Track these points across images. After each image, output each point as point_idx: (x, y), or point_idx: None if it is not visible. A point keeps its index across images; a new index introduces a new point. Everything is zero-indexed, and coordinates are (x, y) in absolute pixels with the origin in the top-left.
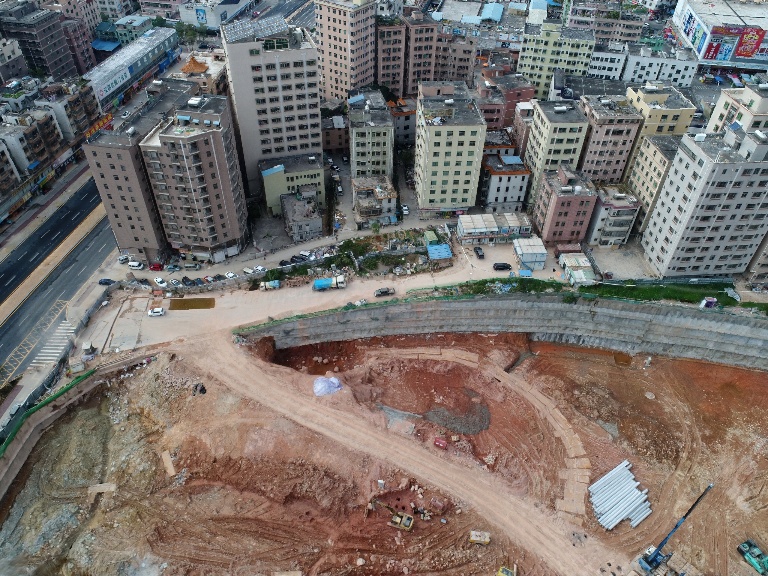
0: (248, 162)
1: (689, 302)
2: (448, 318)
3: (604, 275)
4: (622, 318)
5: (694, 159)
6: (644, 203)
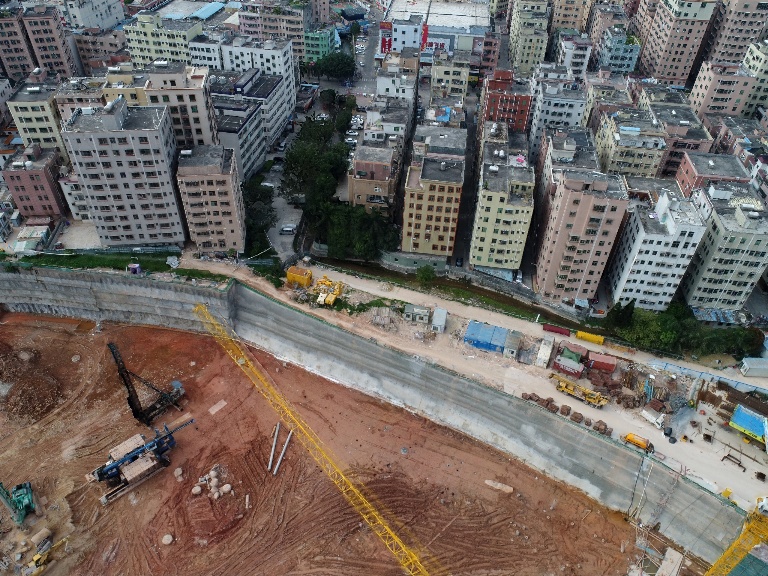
0: None
1: (120, 269)
2: None
3: None
4: (68, 286)
5: None
6: None
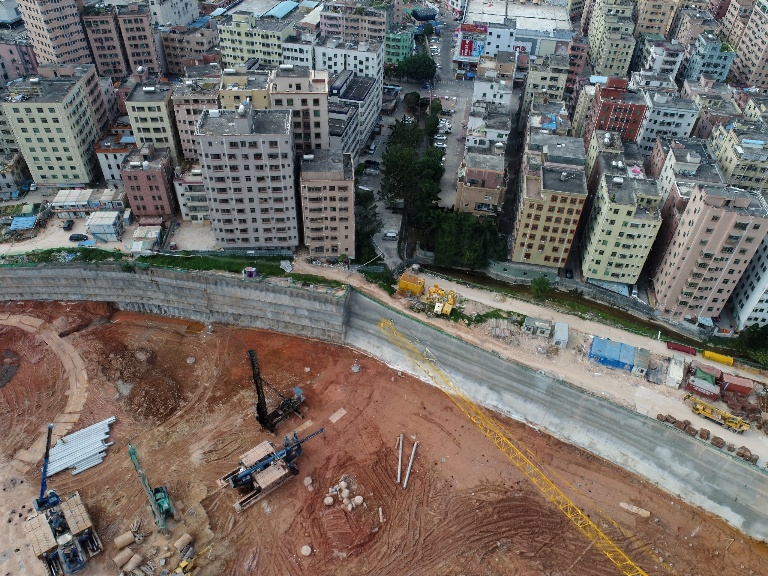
0: None
1: (236, 272)
2: (21, 286)
3: None
4: (181, 287)
5: None
6: None
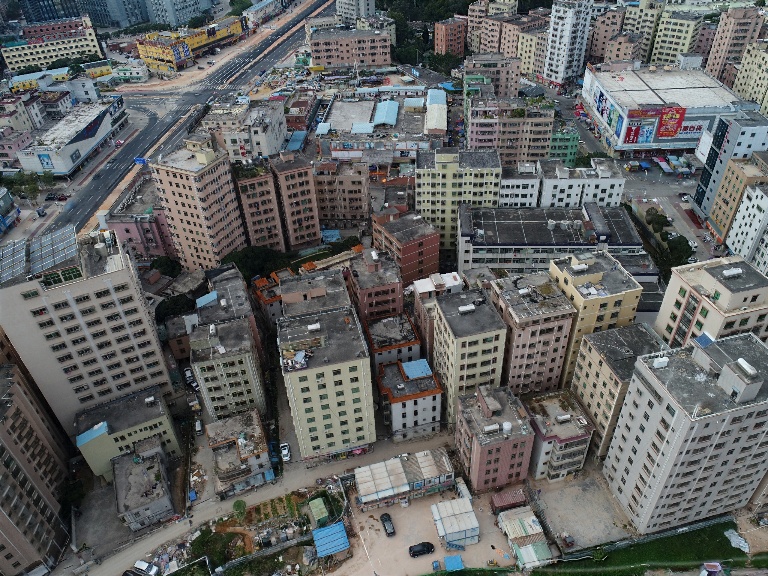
0: (62, 416)
1: (684, 571)
2: None
3: (562, 540)
4: None
5: (659, 400)
6: (597, 423)
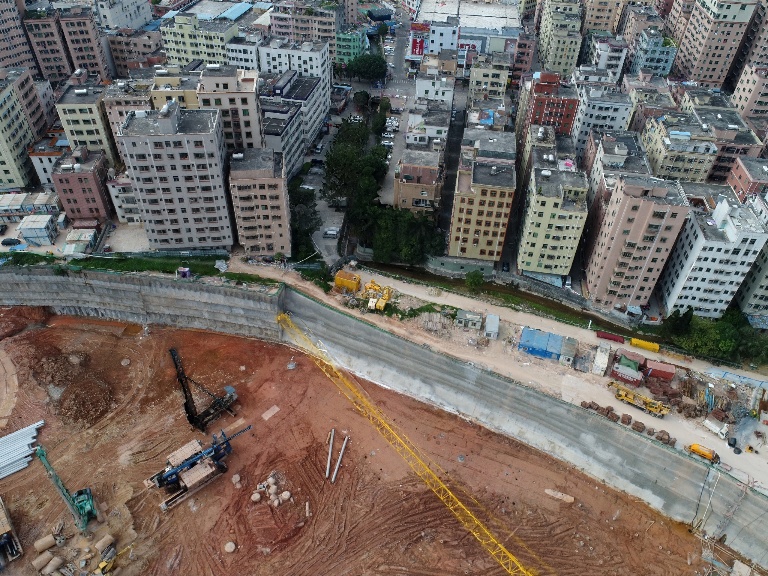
0: None
1: (169, 273)
2: None
3: None
4: (116, 290)
5: None
6: None
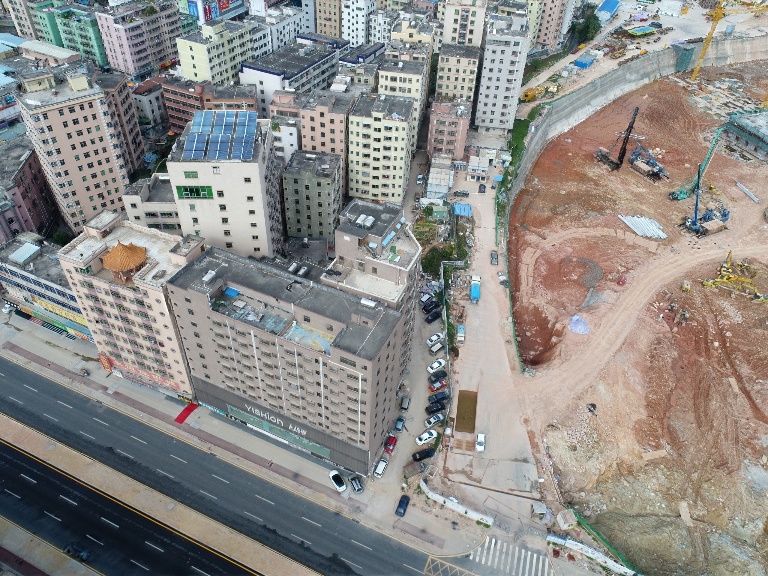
0: None
1: (527, 134)
2: None
3: None
4: None
5: (509, 45)
6: None
